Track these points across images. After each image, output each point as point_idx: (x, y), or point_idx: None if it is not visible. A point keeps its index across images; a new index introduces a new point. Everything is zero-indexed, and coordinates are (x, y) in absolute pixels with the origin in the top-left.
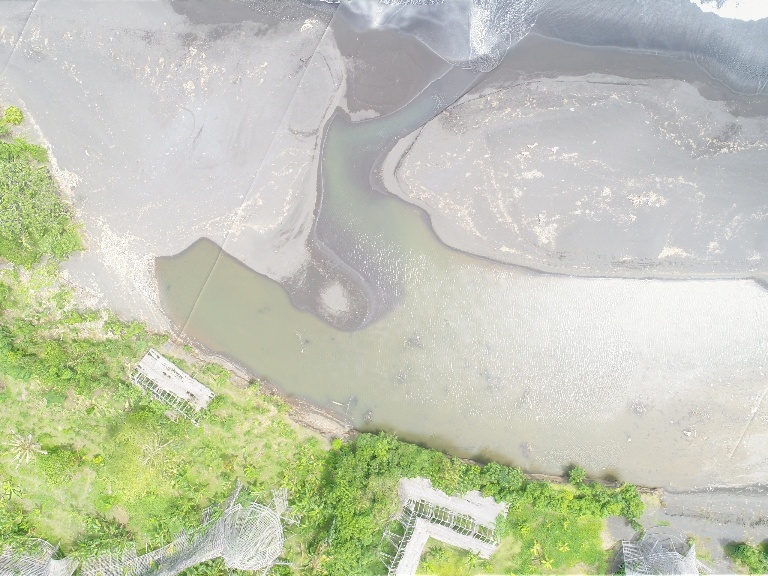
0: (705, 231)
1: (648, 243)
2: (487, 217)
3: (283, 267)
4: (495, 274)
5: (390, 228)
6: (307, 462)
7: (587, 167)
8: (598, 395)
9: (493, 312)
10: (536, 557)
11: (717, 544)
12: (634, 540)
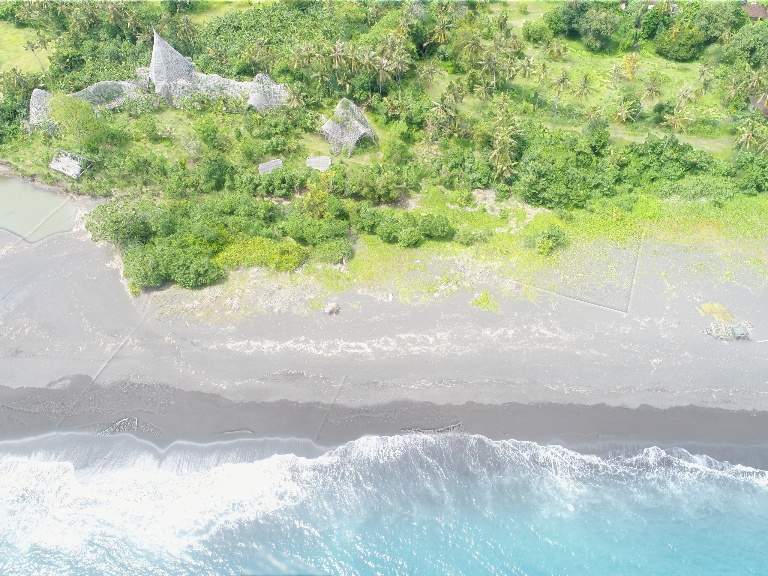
0: None
1: None
2: None
3: None
4: None
5: None
6: (7, 146)
7: None
8: None
9: None
10: None
11: None
12: None
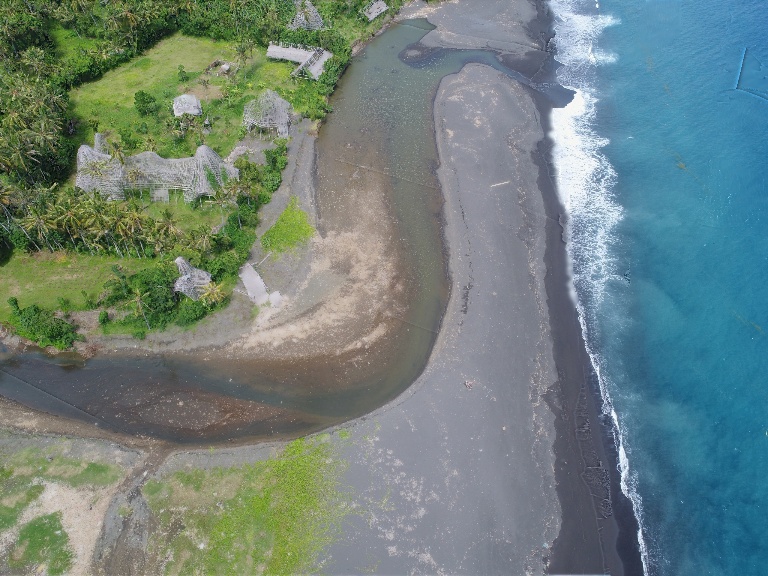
0: None
1: None
2: None
3: (426, 42)
4: None
5: None
6: None
7: None
8: None
9: None
10: None
11: None
12: None
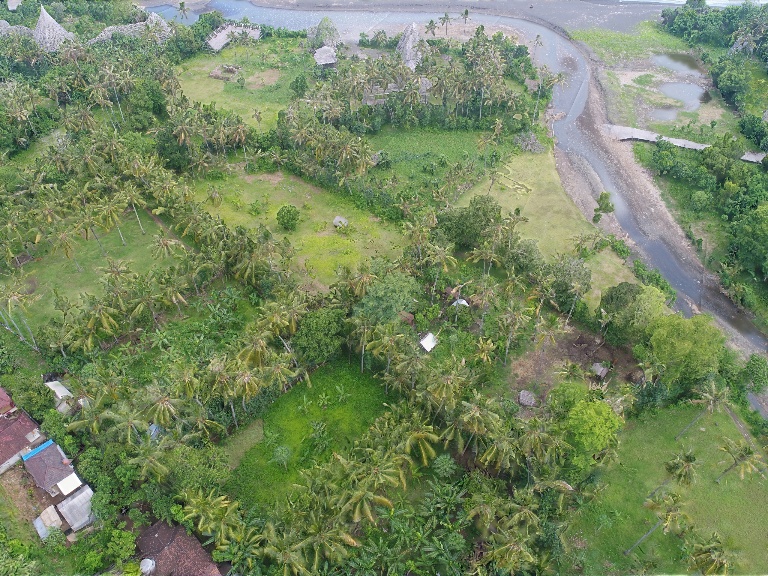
0: None
1: None
2: None
3: (194, 8)
4: (274, 10)
5: (237, 4)
6: None
7: None
8: None
9: None
10: None
11: (354, 44)
12: None
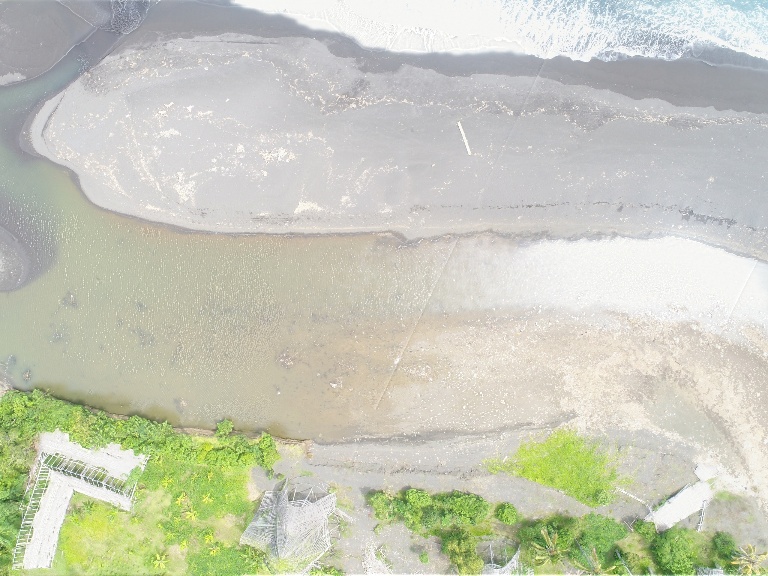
0: (337, 185)
1: (282, 198)
2: (131, 176)
3: None
4: (144, 232)
5: (42, 189)
6: None
7: (222, 125)
8: (247, 349)
9: (144, 270)
10: (186, 509)
11: (358, 493)
12: (277, 490)
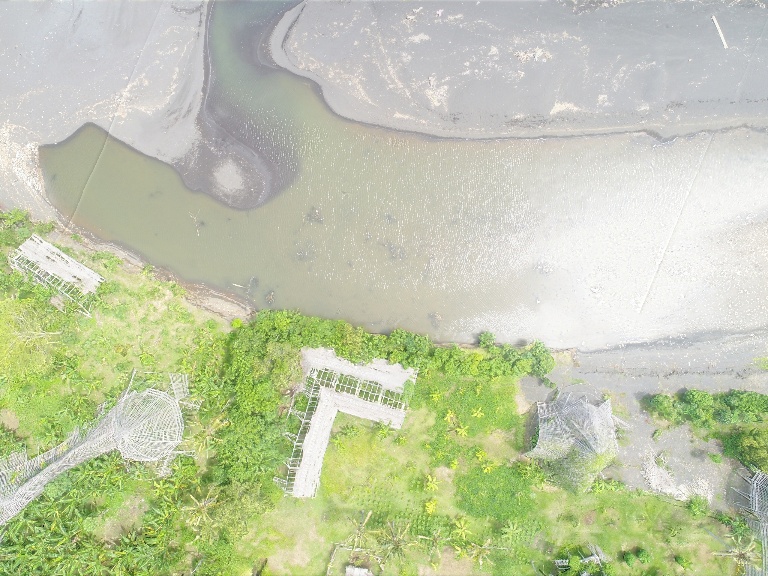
0: (593, 84)
1: (538, 99)
2: (378, 84)
3: (173, 148)
4: (391, 142)
5: (282, 102)
6: (206, 344)
7: (473, 28)
8: (503, 258)
9: (392, 181)
10: (451, 428)
11: (633, 398)
12: (549, 400)
